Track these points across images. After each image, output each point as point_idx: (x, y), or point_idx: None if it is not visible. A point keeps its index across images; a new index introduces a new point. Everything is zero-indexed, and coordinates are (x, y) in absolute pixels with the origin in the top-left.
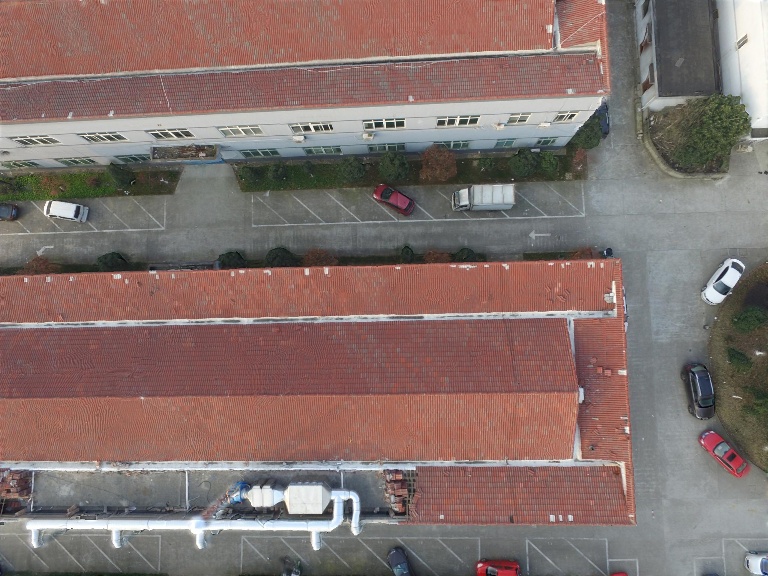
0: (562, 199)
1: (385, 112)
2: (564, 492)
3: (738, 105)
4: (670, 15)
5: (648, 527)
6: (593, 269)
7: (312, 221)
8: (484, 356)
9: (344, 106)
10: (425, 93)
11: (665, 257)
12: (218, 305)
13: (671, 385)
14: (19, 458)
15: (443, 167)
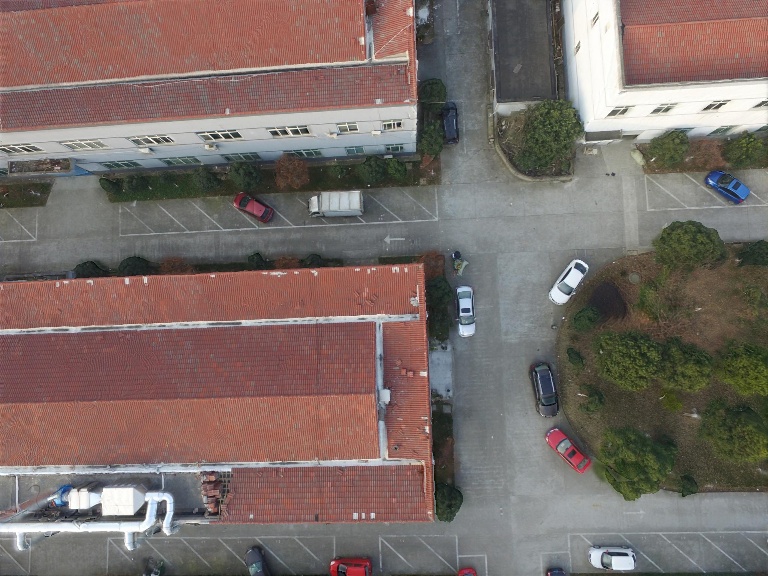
0: (416, 204)
1: (210, 124)
2: (369, 491)
3: (566, 110)
4: (509, 22)
5: (496, 523)
6: (398, 274)
7: (177, 230)
8: (291, 360)
9: (165, 120)
10: (242, 106)
11: (515, 259)
12: (46, 315)
13: (519, 384)
14: None
15: (294, 175)
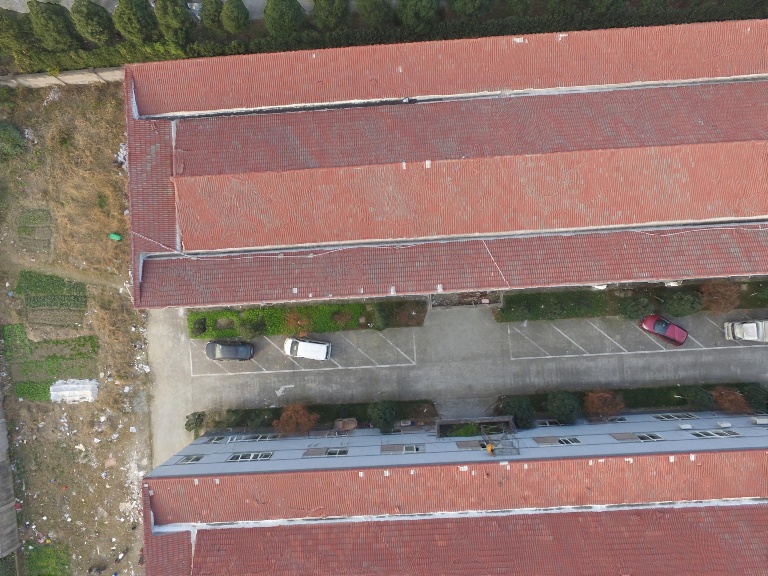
0: None
1: None
2: None
3: None
4: None
5: None
6: None
7: (575, 352)
8: None
9: None
10: None
11: None
12: (571, 493)
13: None
14: None
15: (729, 301)
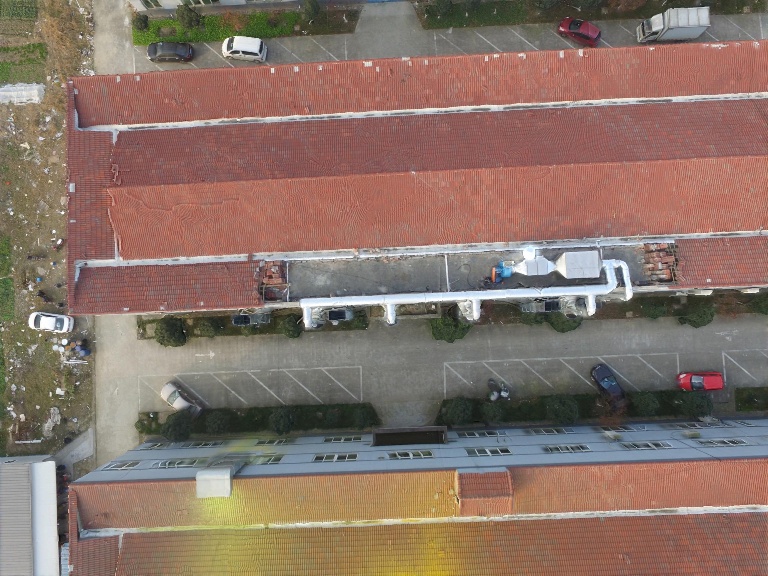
0: (741, 31)
1: None
2: None
3: None
4: None
5: None
6: None
7: None
8: None
9: None
10: None
11: None
12: (470, 92)
13: None
14: (273, 249)
15: None
